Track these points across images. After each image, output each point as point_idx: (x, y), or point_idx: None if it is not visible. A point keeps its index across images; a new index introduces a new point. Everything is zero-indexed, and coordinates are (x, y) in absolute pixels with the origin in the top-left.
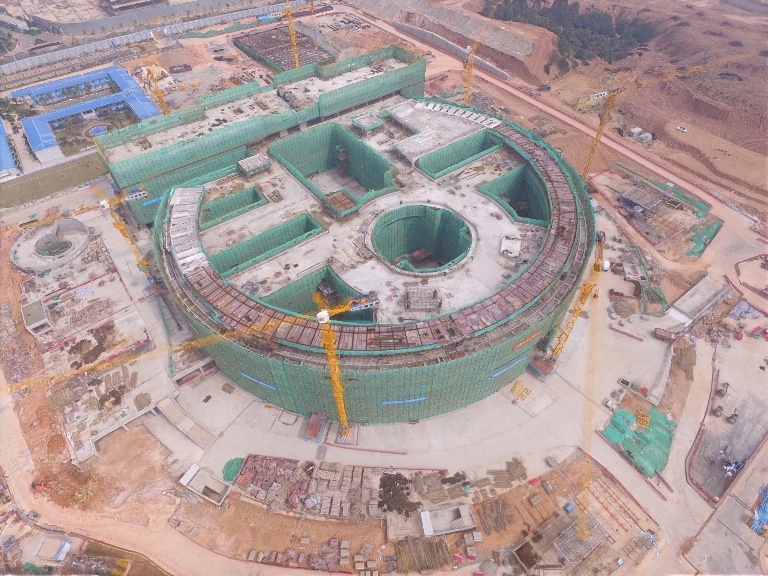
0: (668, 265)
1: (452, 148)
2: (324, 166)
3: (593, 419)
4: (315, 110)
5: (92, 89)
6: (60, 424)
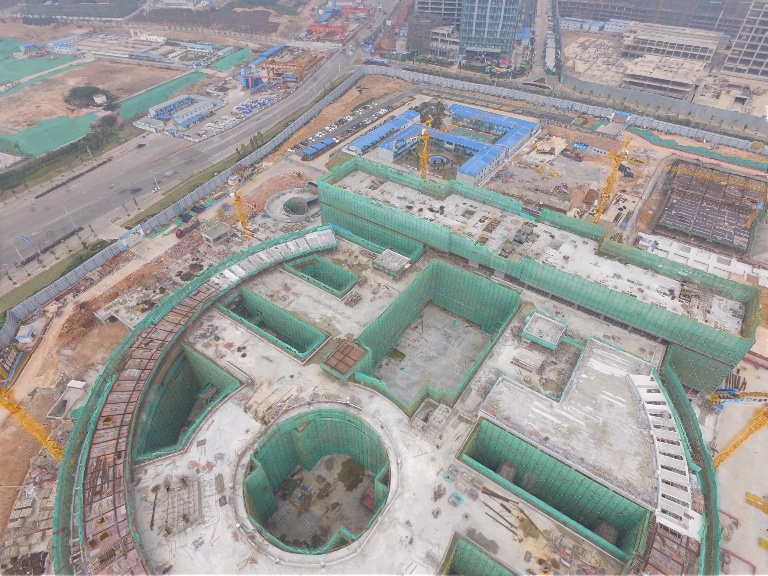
0: None
1: (553, 463)
2: (491, 328)
3: None
4: (517, 269)
5: (493, 131)
6: (127, 291)
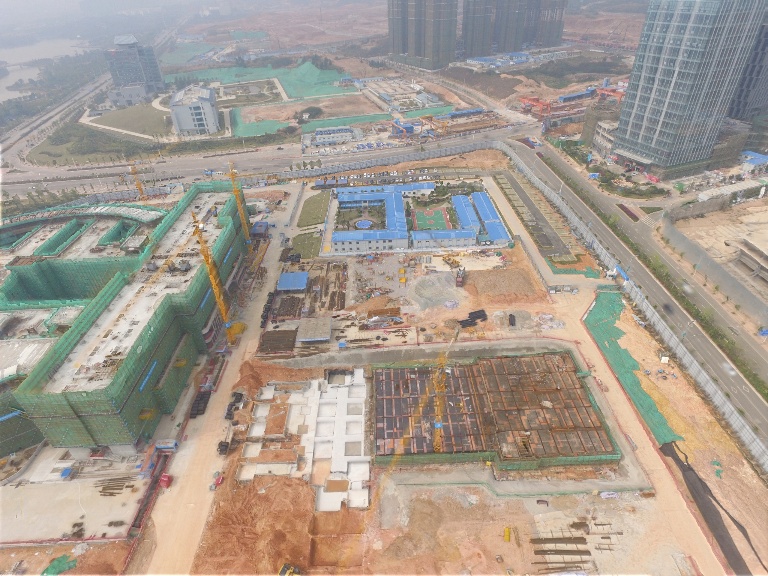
0: None
1: None
2: None
3: None
4: None
5: (459, 226)
6: None
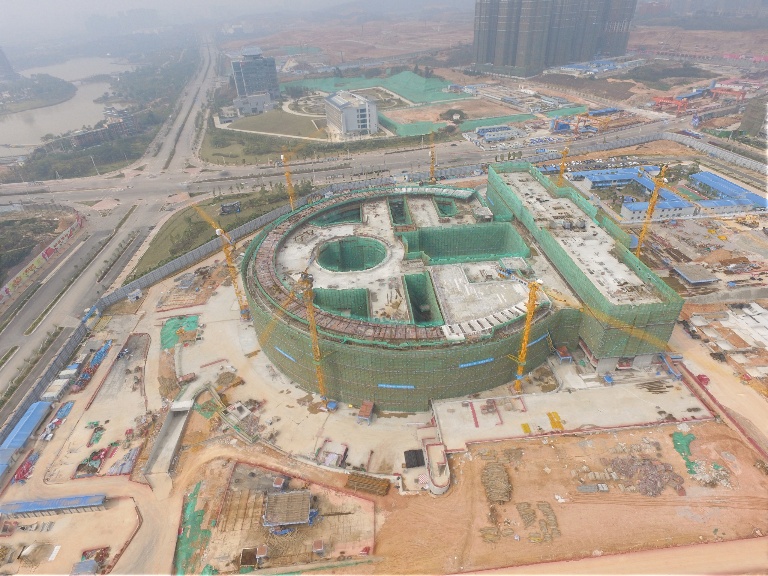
0: (212, 450)
1: None
2: None
3: (206, 317)
4: None
5: (717, 198)
6: None
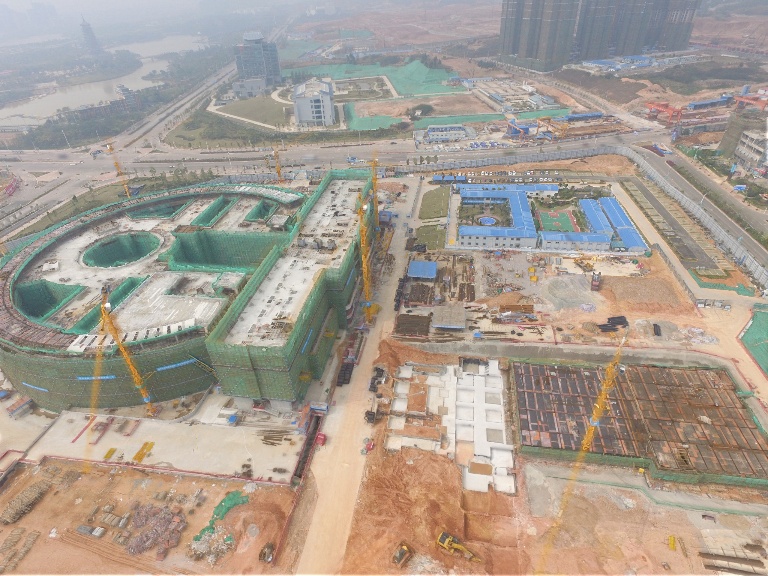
0: None
1: None
2: None
3: None
4: None
5: (588, 230)
6: None
